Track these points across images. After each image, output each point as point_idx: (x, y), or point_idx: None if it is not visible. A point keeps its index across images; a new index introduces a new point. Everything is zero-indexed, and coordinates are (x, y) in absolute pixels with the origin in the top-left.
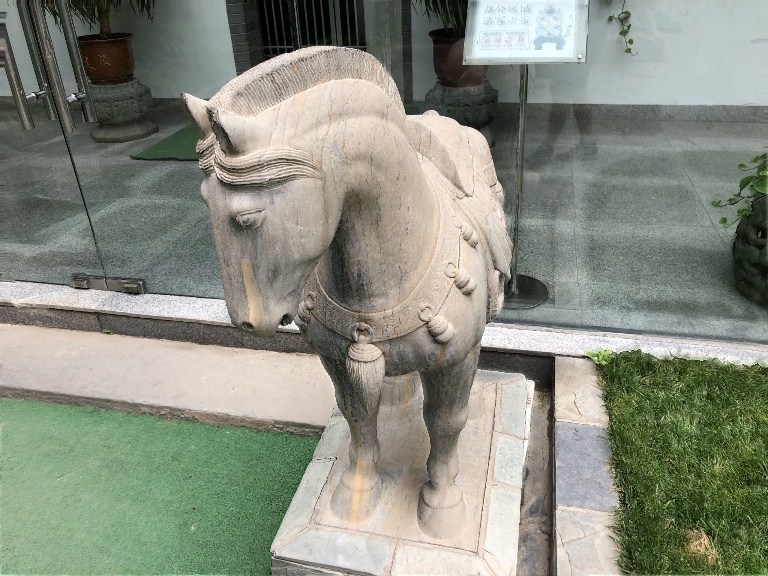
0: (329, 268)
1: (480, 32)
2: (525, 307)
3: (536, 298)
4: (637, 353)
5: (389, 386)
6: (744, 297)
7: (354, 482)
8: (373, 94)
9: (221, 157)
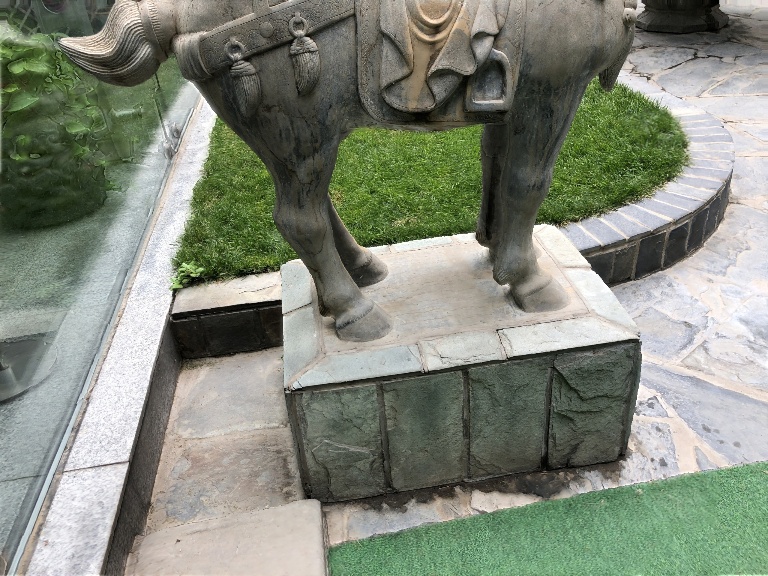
0: None
1: None
2: (56, 349)
3: (32, 344)
4: (184, 252)
5: (376, 305)
6: (64, 223)
7: (546, 271)
8: None
9: None
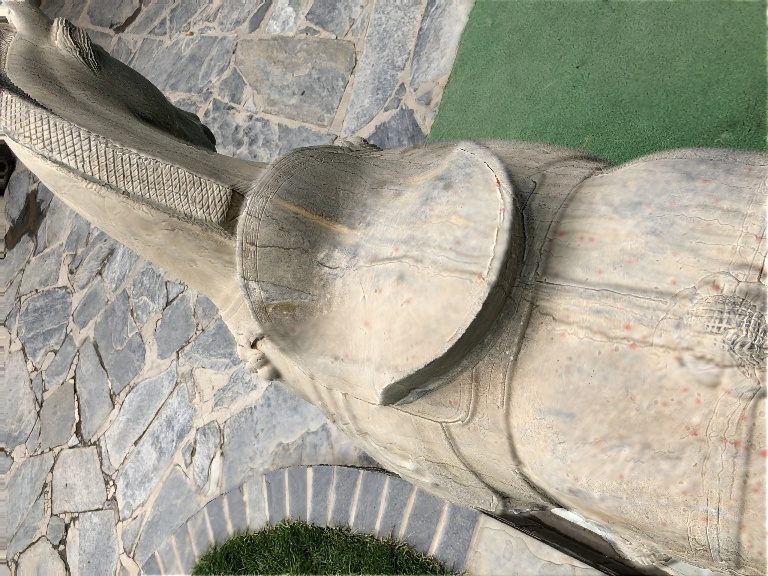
0: None
1: None
2: None
3: None
4: None
5: None
6: None
7: None
8: (29, 166)
9: None
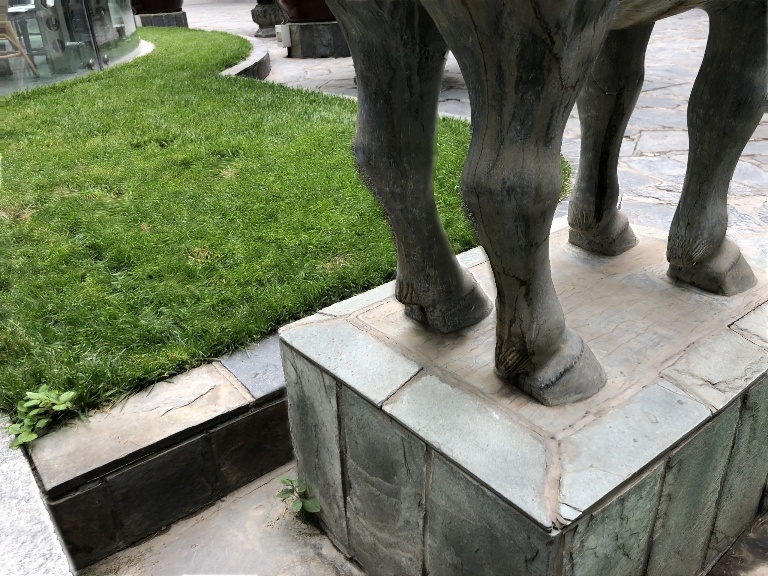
0: None
1: None
2: None
3: None
4: (12, 375)
5: None
6: None
7: None
8: None
9: None
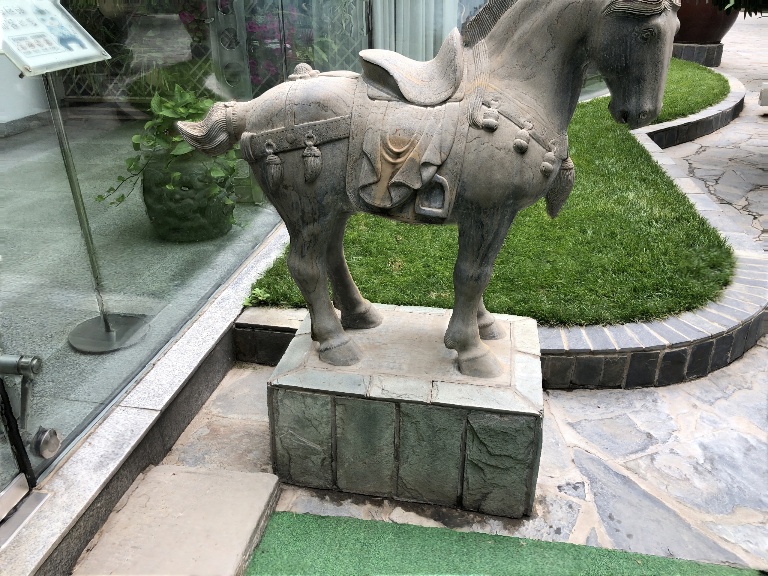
0: (563, 111)
1: (8, 38)
2: (148, 327)
3: (135, 320)
4: (262, 280)
5: (352, 341)
6: (193, 242)
7: (486, 346)
8: None
9: None
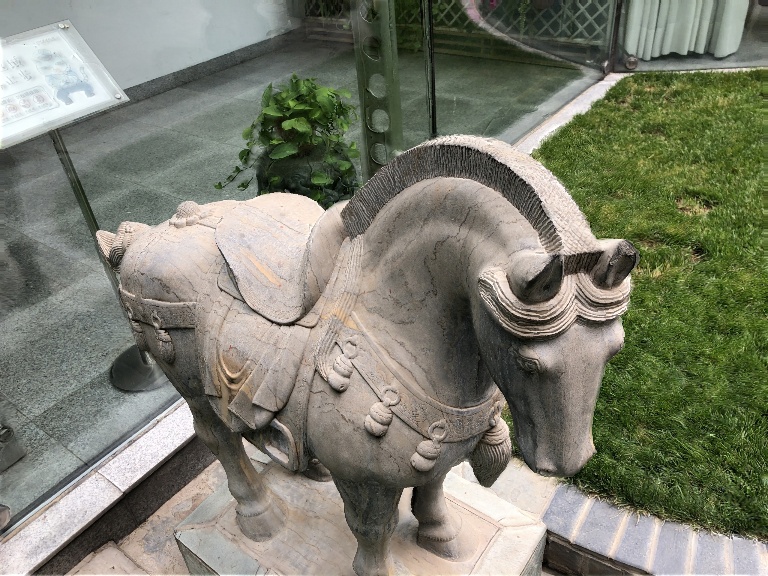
0: (465, 378)
1: None
2: None
3: None
4: None
5: (268, 512)
6: None
7: None
8: None
9: (604, 295)
